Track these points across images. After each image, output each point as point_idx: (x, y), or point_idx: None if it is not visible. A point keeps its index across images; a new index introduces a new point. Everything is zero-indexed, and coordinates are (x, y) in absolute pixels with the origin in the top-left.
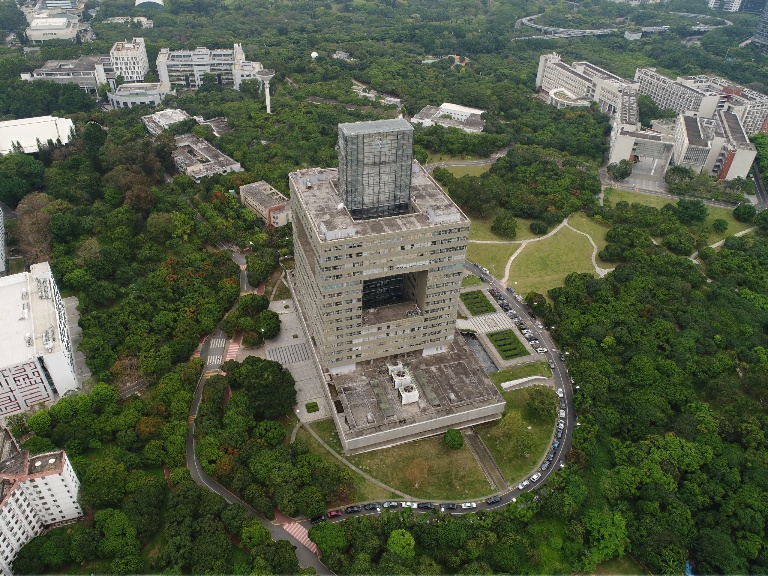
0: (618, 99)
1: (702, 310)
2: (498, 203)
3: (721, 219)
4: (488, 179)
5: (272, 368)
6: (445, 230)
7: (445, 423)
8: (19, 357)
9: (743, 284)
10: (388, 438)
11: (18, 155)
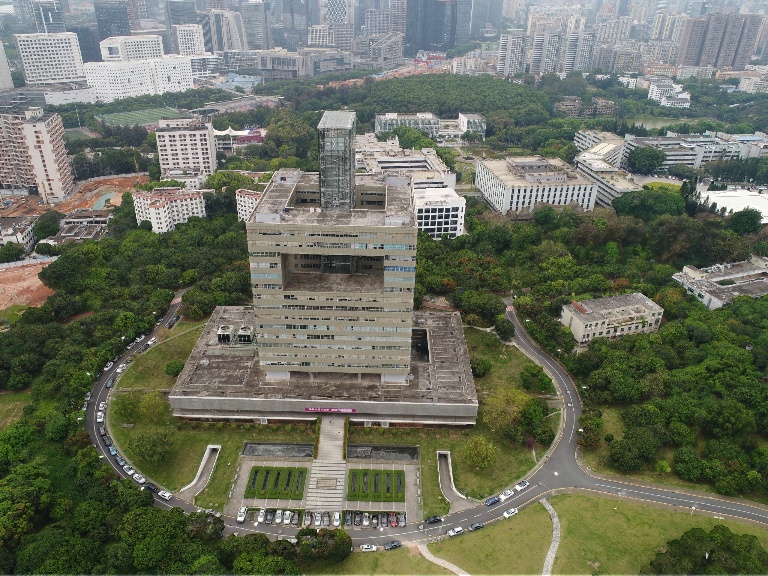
0: None
1: None
2: None
3: None
4: None
5: None
6: None
7: None
8: None
9: None
10: None
11: (674, 195)
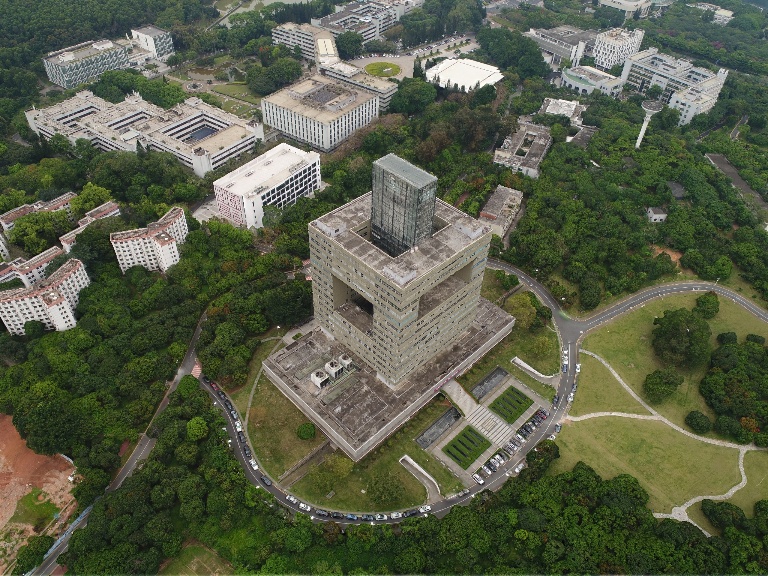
0: None
1: None
2: (691, 364)
3: None
4: (745, 343)
5: (293, 292)
6: (384, 281)
7: None
8: (244, 191)
9: None
10: None
11: (426, 85)
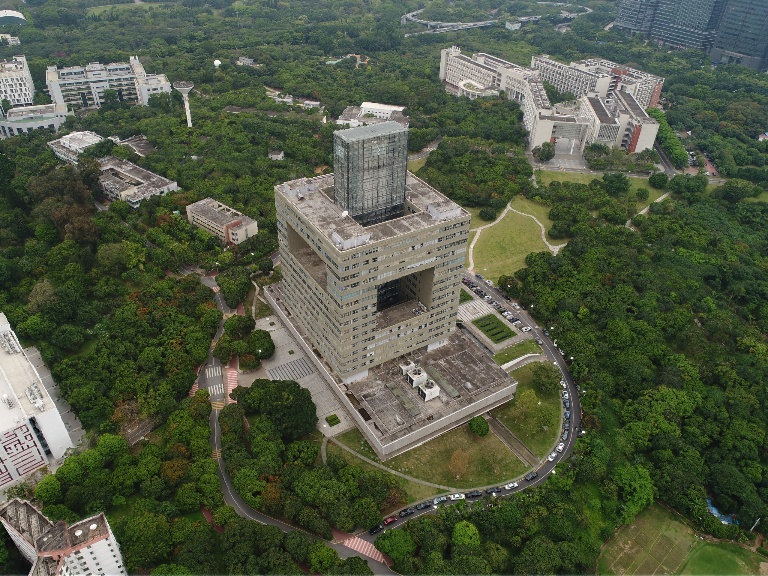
0: (525, 86)
1: (653, 272)
2: (446, 195)
3: (642, 188)
4: (427, 173)
5: (290, 387)
6: (450, 226)
7: (468, 412)
8: (3, 422)
9: (676, 244)
10: (419, 436)
11: None
